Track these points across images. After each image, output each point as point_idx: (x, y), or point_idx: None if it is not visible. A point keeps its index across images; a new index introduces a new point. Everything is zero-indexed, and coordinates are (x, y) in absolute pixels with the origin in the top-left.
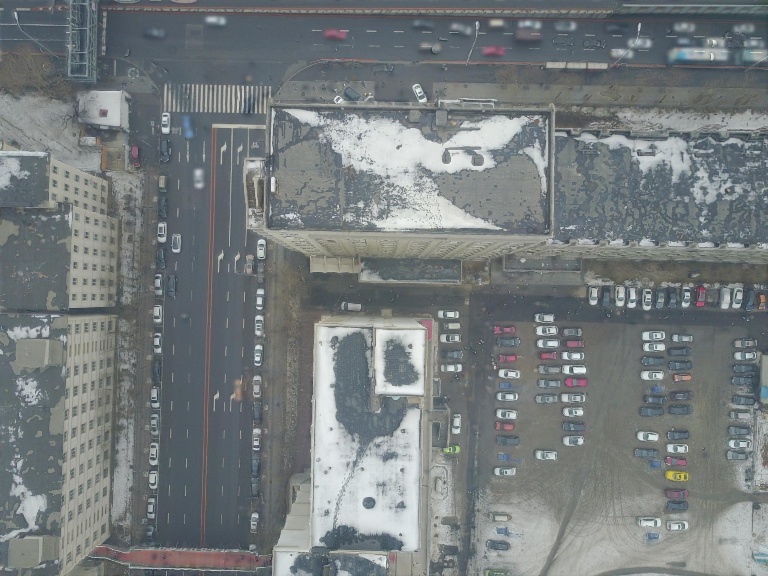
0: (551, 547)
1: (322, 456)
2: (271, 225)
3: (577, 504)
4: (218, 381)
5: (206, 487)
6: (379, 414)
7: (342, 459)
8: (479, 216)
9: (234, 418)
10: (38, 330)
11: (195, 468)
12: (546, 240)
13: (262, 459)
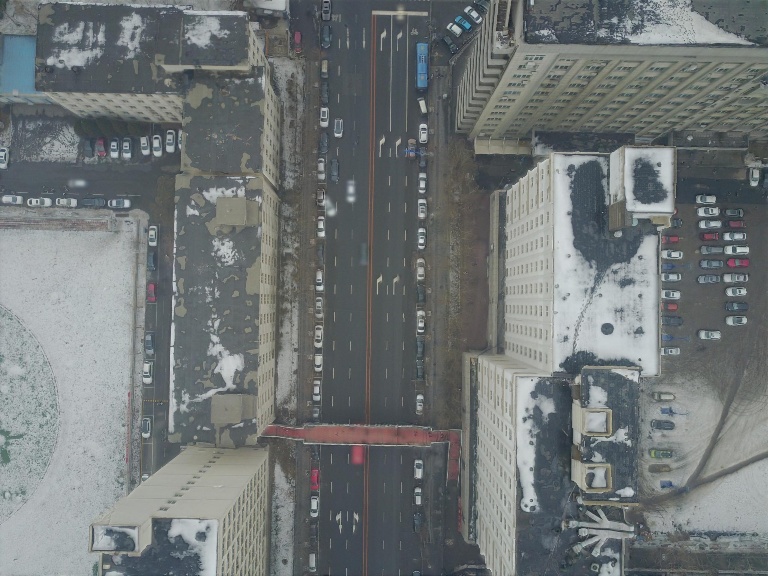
0: (715, 427)
1: (560, 283)
2: (526, 41)
3: (740, 384)
4: (380, 265)
5: (370, 370)
6: (616, 241)
7: (580, 285)
8: (732, 31)
9: (397, 301)
10: (234, 191)
11: (359, 351)
12: (760, 82)
13: (426, 341)
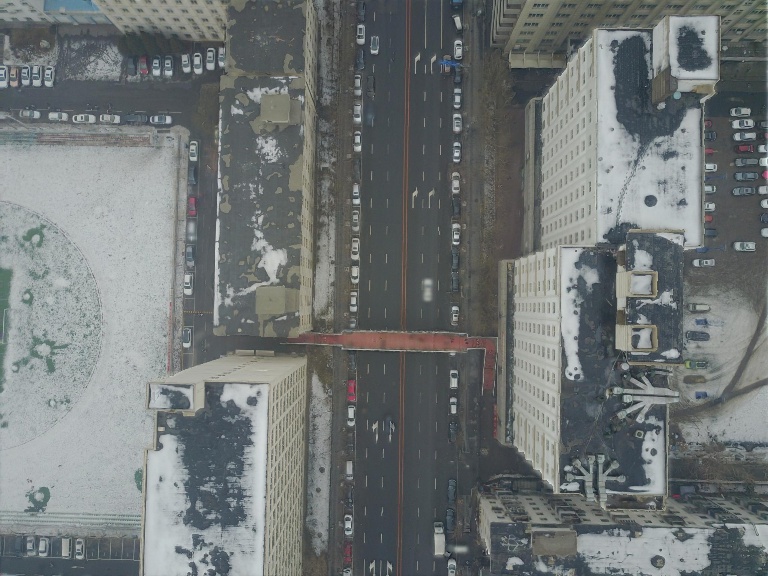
0: (751, 338)
1: (604, 156)
2: None
3: None
4: (416, 179)
5: (406, 282)
6: (659, 115)
7: (624, 158)
8: None
9: (432, 215)
10: (277, 90)
11: (395, 264)
12: None
13: (461, 254)
